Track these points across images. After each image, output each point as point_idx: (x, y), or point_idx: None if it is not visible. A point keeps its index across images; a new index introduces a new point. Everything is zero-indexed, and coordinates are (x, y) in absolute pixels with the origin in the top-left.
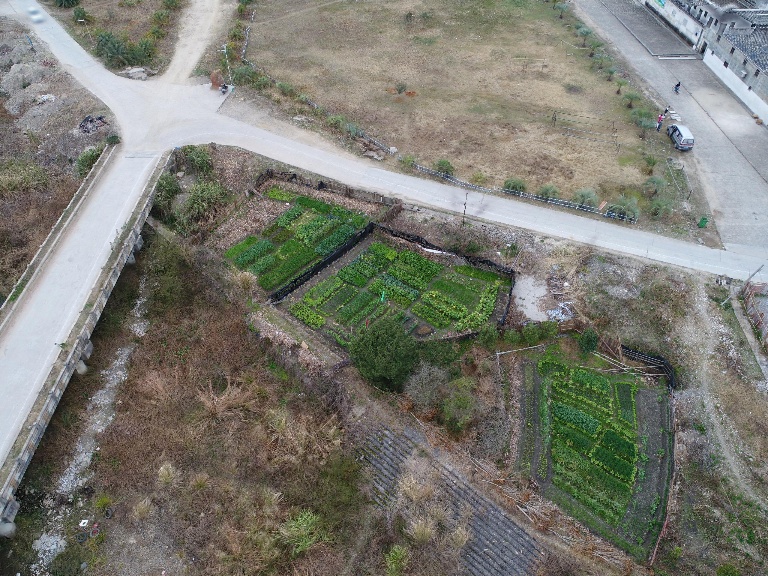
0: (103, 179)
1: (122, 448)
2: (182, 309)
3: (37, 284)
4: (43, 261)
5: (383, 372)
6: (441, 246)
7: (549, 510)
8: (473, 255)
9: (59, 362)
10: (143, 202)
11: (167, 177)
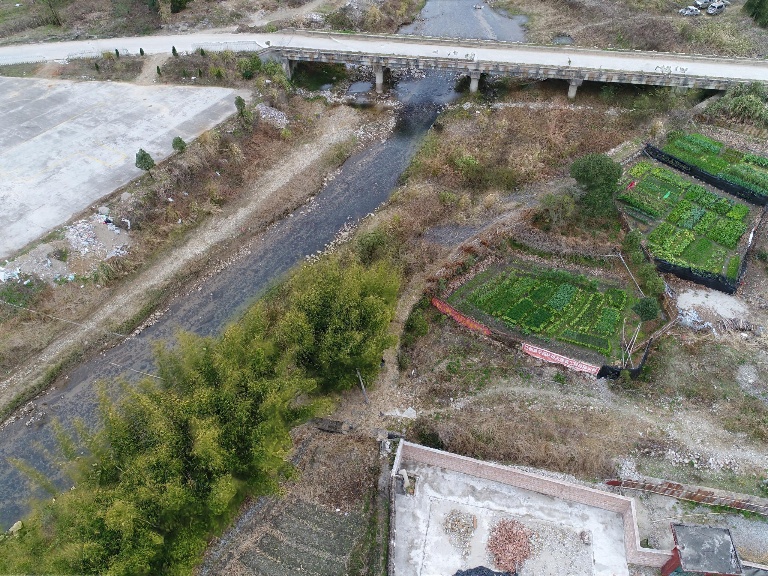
0: (743, 66)
1: (518, 111)
2: (632, 124)
3: (622, 57)
4: (641, 53)
5: (572, 168)
6: (766, 250)
7: (474, 248)
8: (763, 272)
9: (560, 67)
10: (721, 79)
11: (760, 85)
